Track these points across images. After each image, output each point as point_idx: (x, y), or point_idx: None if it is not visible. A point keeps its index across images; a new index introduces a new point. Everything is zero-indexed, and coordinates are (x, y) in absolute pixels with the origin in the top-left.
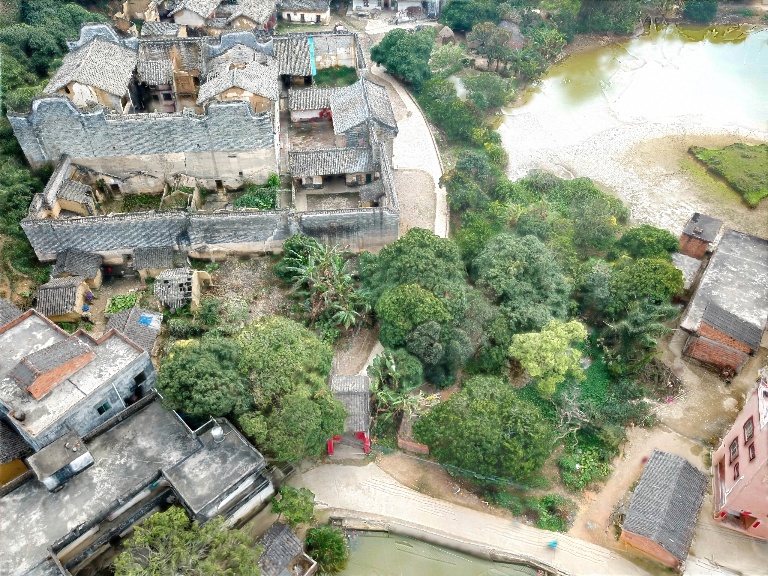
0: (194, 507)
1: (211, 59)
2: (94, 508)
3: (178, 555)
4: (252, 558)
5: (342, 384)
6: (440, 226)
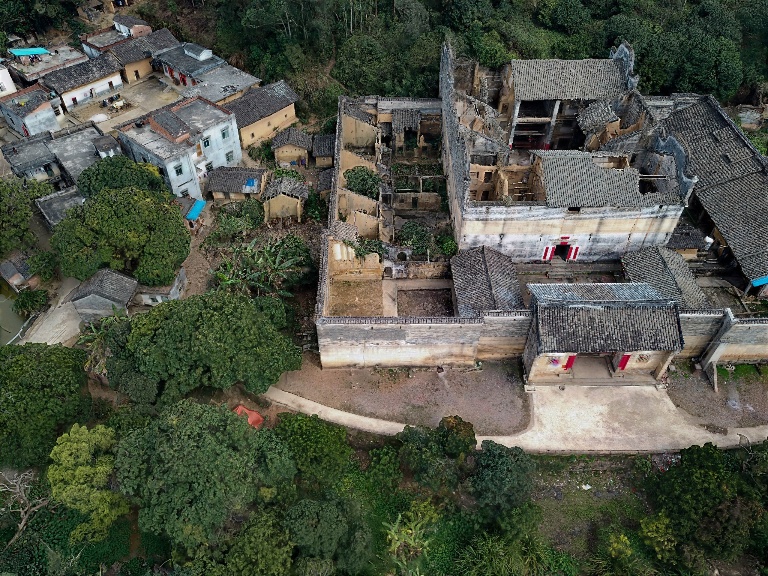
0: (46, 203)
1: (653, 151)
2: (74, 168)
3: (4, 189)
4: (6, 235)
5: (118, 282)
6: (384, 426)
